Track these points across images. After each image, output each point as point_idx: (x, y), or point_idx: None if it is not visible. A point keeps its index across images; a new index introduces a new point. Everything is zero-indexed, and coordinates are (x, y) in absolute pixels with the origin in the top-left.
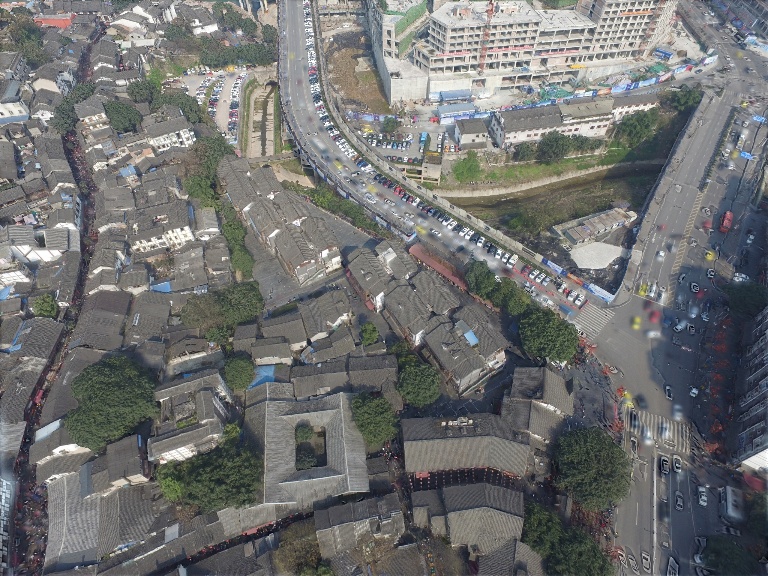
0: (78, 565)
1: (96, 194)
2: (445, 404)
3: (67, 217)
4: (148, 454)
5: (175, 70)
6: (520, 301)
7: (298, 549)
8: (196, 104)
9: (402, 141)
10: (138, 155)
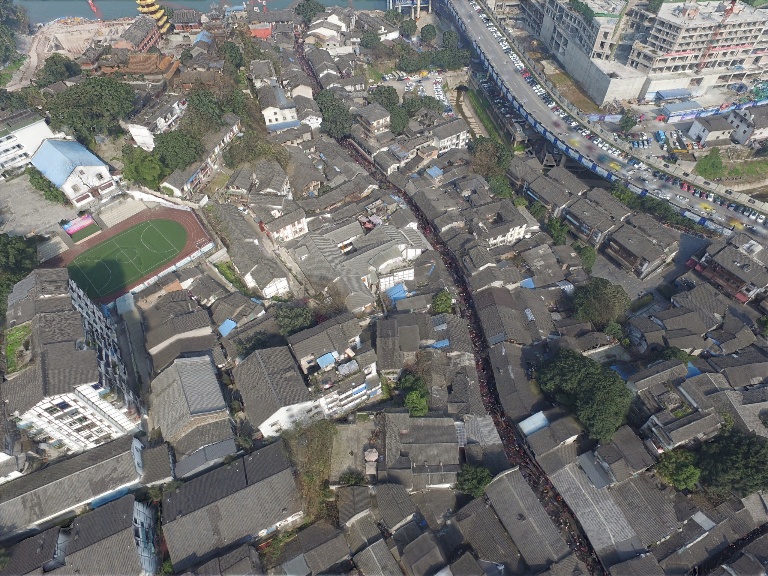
0: (634, 553)
1: None
2: None
3: (411, 217)
4: (664, 443)
5: (375, 76)
6: None
7: None
8: (444, 107)
9: (641, 140)
10: (428, 157)
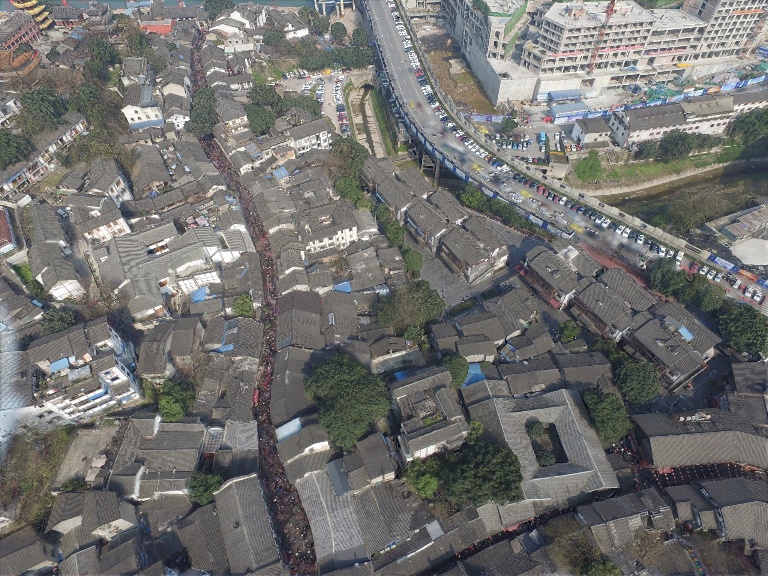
0: (353, 562)
1: (246, 196)
2: (657, 400)
3: (238, 219)
4: (404, 451)
5: (275, 74)
6: (716, 297)
7: (580, 544)
8: (320, 107)
9: (521, 141)
10: (282, 157)
